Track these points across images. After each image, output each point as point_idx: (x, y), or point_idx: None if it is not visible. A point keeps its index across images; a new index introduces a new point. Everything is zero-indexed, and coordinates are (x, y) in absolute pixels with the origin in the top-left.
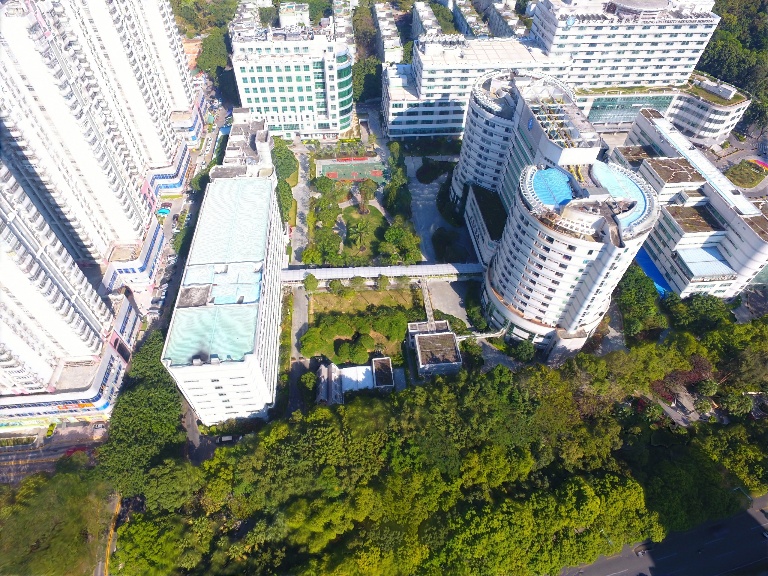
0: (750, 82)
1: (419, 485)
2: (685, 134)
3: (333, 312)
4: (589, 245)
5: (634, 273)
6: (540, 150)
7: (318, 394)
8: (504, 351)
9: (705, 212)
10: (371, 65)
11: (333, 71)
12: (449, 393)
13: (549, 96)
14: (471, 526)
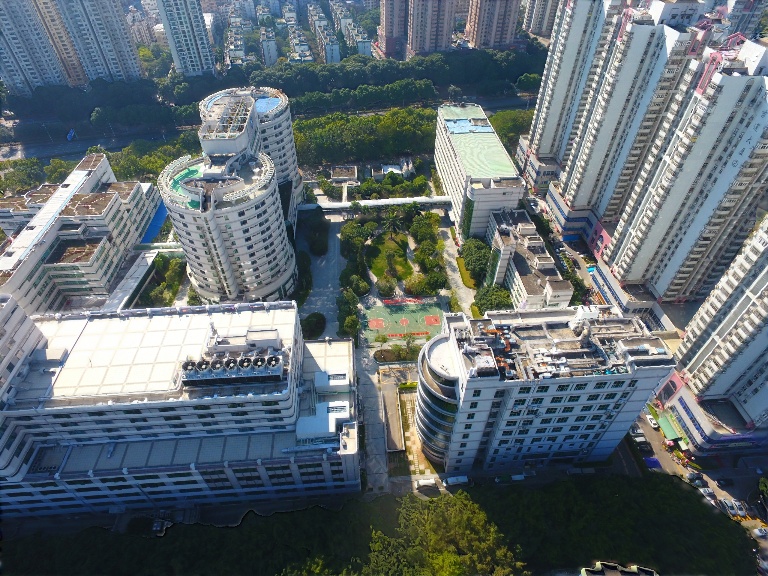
0: None
1: None
2: None
3: None
4: None
5: None
6: None
7: None
8: None
9: None
10: (381, 568)
11: None
12: None
13: None
14: None
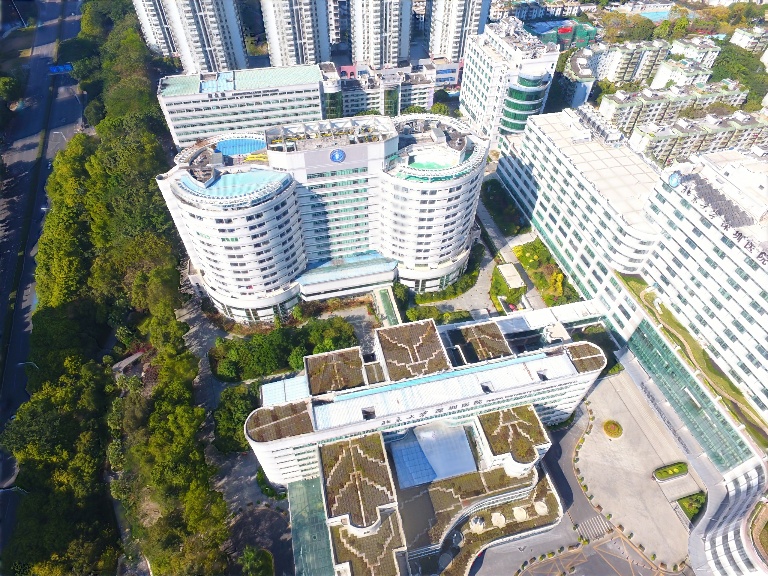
0: None
1: None
2: (710, 527)
3: None
4: None
5: (276, 333)
6: None
7: None
8: None
9: None
10: None
11: (501, 83)
12: None
13: None
14: None
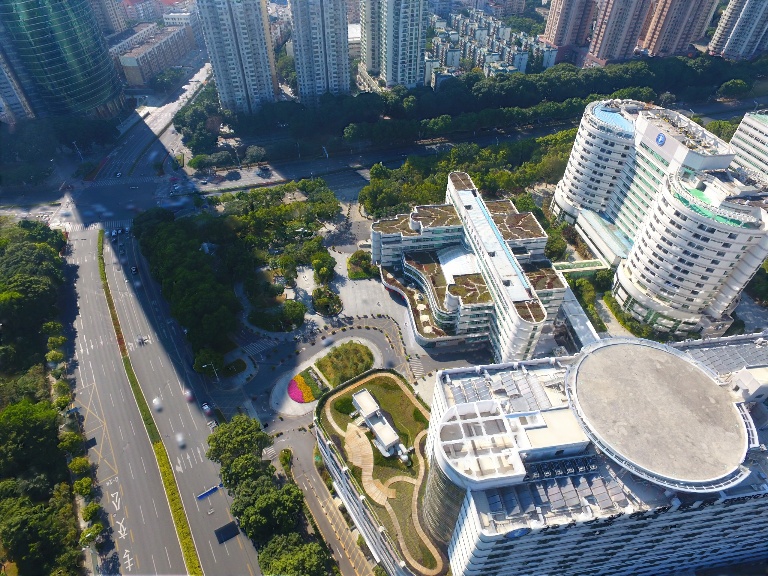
0: None
1: None
2: None
3: None
4: None
5: None
6: None
7: None
8: None
9: None
10: None
11: None
12: None
13: None
14: None
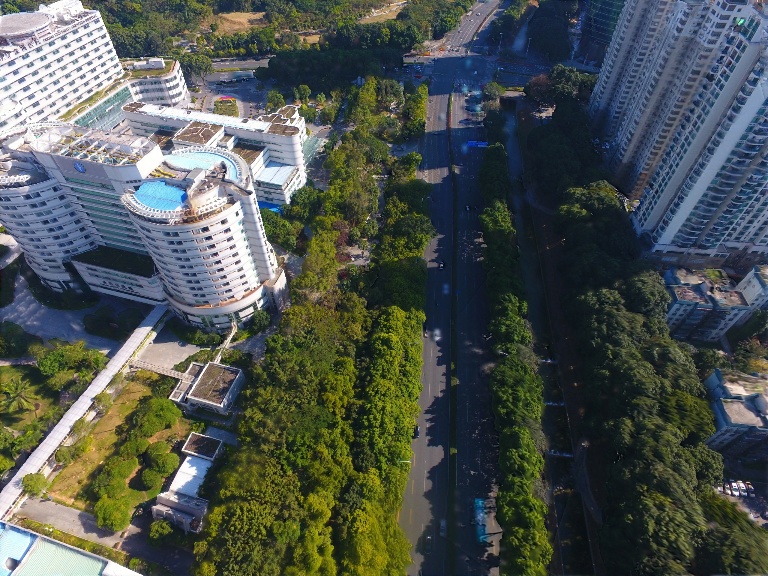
0: (157, 49)
1: (326, 451)
2: None
3: (92, 474)
4: (232, 210)
5: None
6: (115, 180)
7: (182, 525)
8: (250, 335)
9: (243, 145)
10: None
11: None
12: (266, 389)
13: (62, 137)
14: (374, 424)
